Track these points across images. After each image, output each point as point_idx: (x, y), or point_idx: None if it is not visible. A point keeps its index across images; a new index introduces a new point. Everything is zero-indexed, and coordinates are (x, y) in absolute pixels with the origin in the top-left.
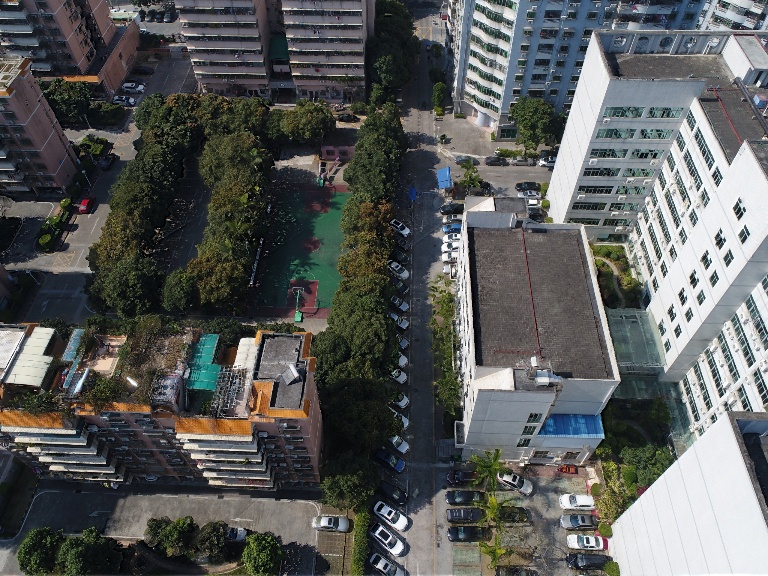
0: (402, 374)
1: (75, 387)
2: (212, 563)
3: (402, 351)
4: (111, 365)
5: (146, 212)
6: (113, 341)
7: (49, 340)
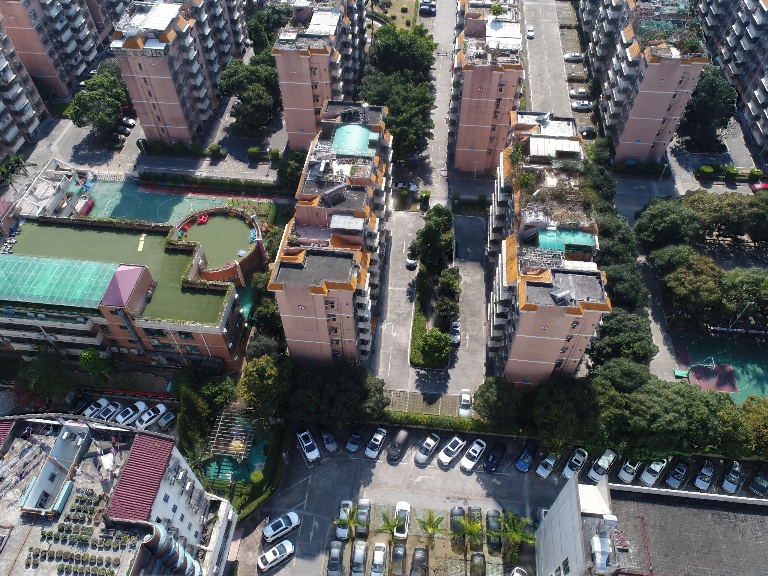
0: (630, 476)
1: None
2: (435, 323)
3: (663, 481)
4: (553, 185)
5: (760, 218)
6: (575, 183)
7: (569, 151)
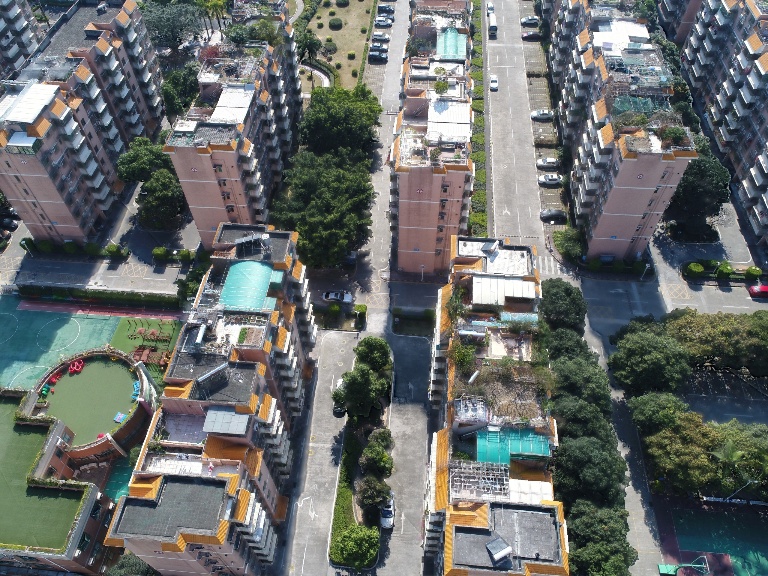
0: None
1: (469, 330)
2: None
3: None
4: (498, 355)
5: (762, 351)
6: (527, 350)
7: (522, 297)
